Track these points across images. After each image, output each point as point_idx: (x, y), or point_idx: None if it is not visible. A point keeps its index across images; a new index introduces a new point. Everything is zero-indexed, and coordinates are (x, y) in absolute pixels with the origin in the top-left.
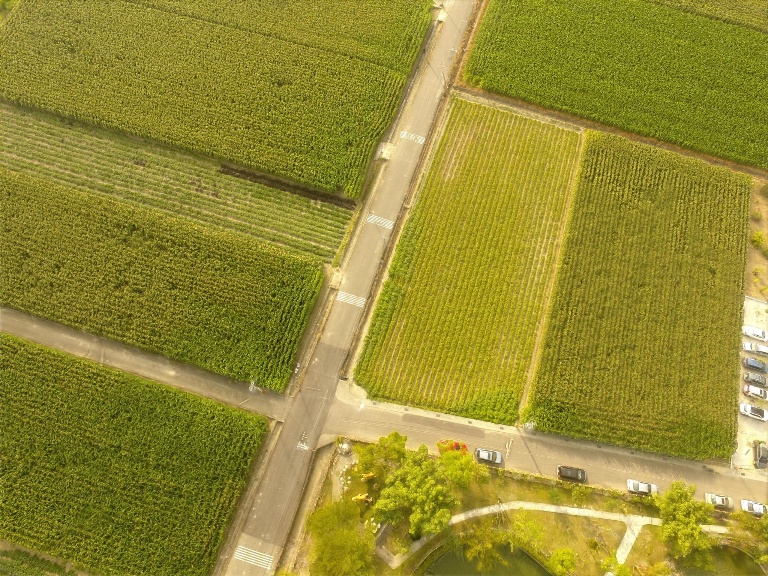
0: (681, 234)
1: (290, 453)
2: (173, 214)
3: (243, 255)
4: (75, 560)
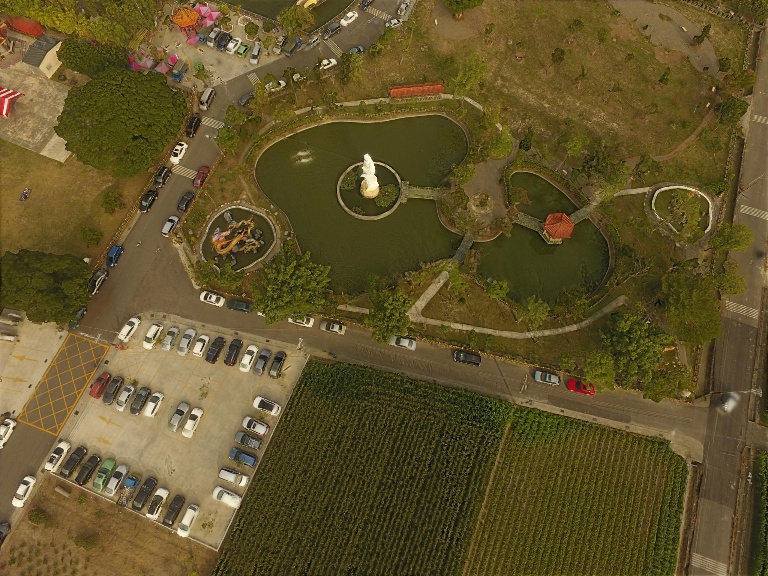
0: None
1: None
2: None
3: None
4: None
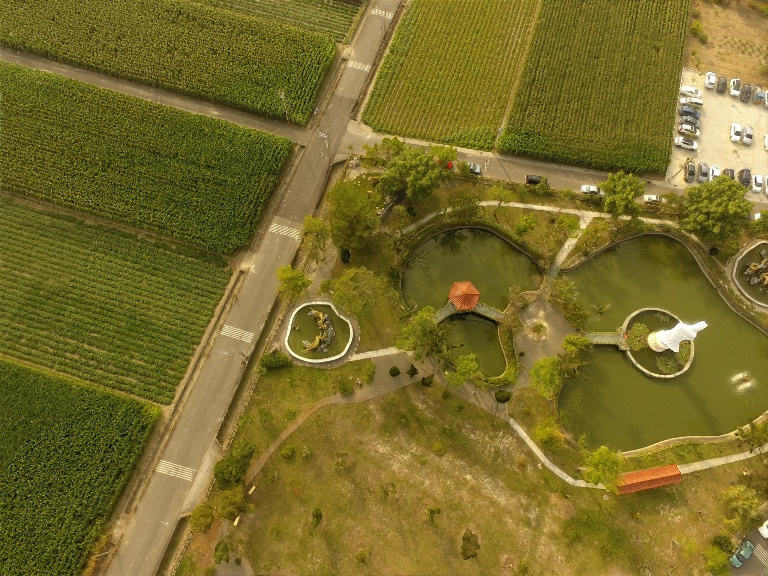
0: (632, 22)
1: (311, 165)
2: (211, 7)
3: (270, 31)
4: (146, 225)
